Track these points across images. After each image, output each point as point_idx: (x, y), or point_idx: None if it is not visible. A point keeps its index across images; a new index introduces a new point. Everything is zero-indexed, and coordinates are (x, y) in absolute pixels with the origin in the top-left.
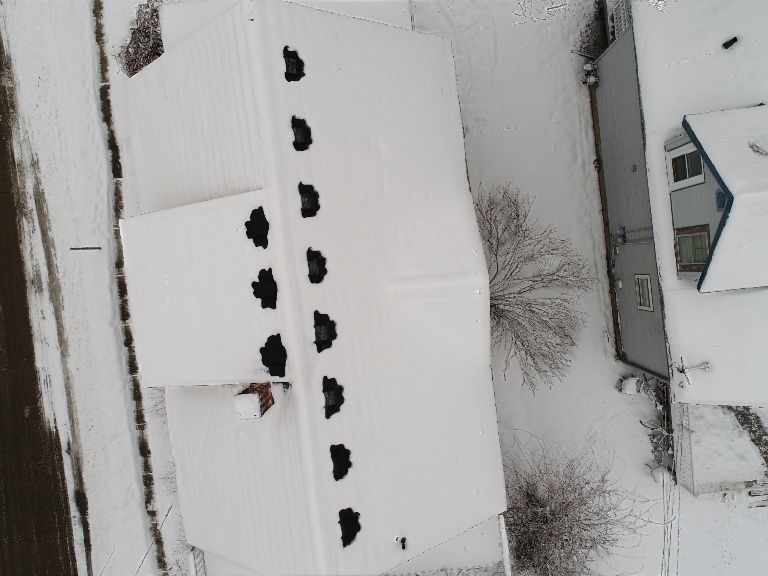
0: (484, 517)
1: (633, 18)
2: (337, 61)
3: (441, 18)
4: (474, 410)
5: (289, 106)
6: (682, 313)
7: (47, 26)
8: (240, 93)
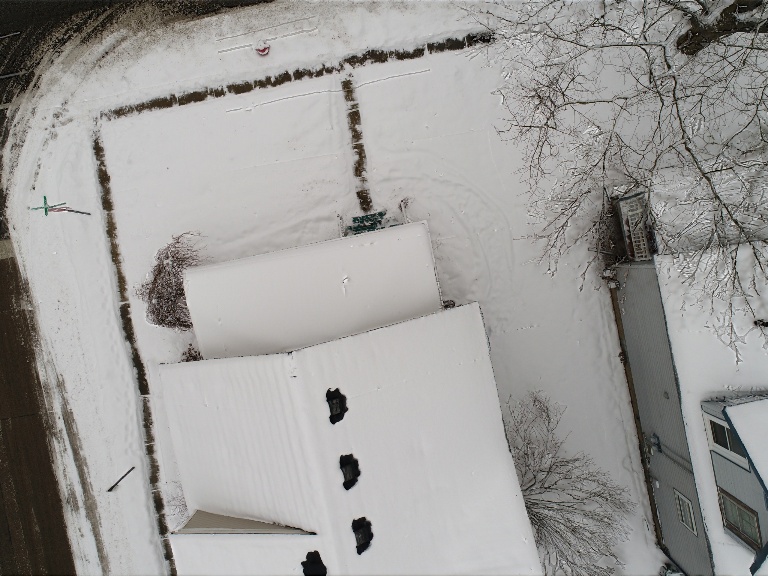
0: None
1: (659, 278)
2: (376, 380)
3: (455, 223)
4: None
5: (336, 449)
6: (732, 568)
7: (62, 250)
8: (286, 439)
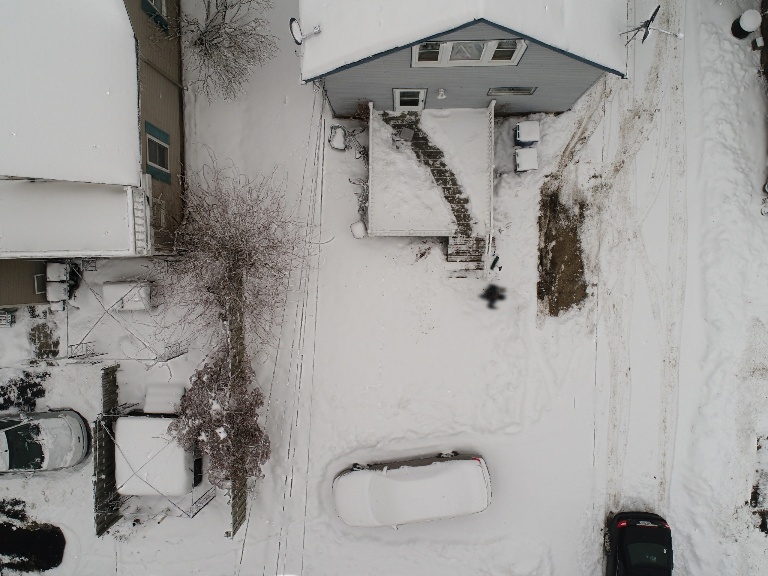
0: (102, 177)
1: None
2: None
3: None
4: (102, 68)
5: None
6: None
7: None
8: None
